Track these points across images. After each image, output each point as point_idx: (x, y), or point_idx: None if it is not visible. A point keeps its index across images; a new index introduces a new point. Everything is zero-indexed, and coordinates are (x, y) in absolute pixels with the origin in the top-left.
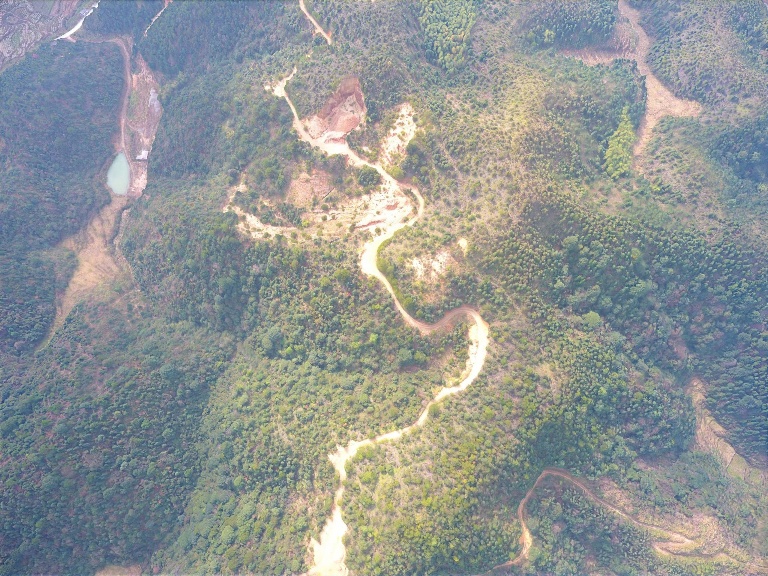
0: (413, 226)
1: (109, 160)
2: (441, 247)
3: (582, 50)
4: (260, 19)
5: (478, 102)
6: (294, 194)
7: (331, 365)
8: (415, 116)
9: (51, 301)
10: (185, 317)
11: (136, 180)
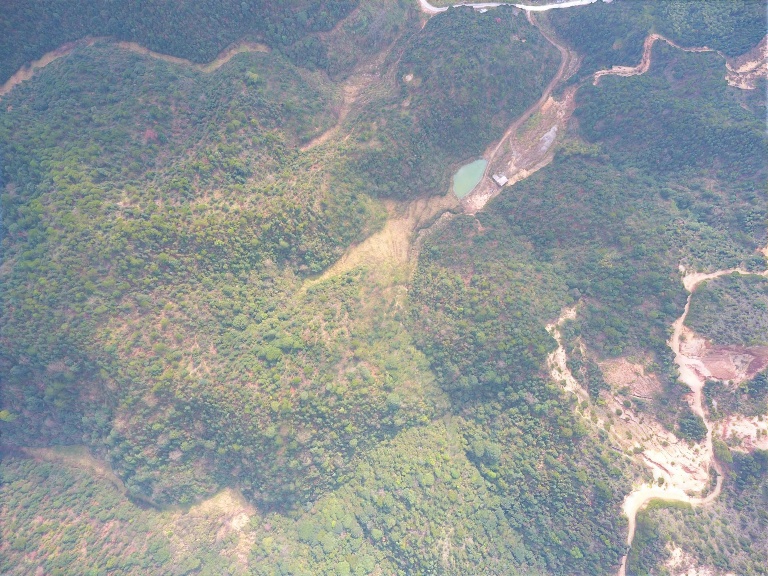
0: (696, 511)
1: (472, 159)
2: (711, 564)
3: None
4: (717, 176)
5: None
6: (612, 367)
7: (516, 522)
8: None
9: (346, 246)
10: (428, 353)
11: (478, 195)
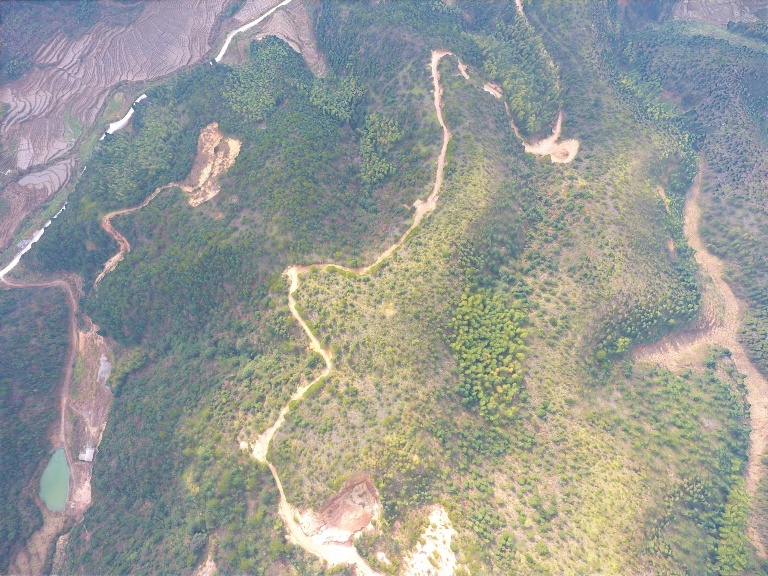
0: None
1: (43, 463)
2: None
3: (660, 340)
4: (238, 300)
5: (543, 514)
6: None
7: None
8: (454, 548)
9: None
10: None
11: (77, 491)
